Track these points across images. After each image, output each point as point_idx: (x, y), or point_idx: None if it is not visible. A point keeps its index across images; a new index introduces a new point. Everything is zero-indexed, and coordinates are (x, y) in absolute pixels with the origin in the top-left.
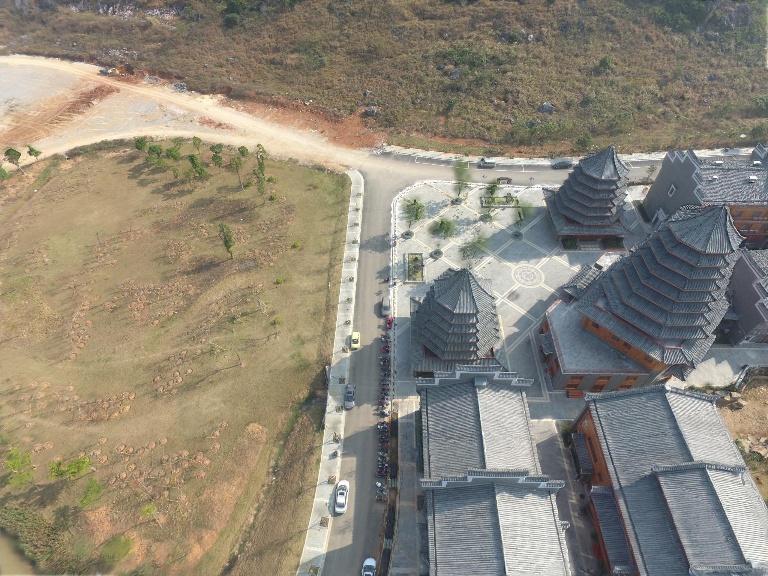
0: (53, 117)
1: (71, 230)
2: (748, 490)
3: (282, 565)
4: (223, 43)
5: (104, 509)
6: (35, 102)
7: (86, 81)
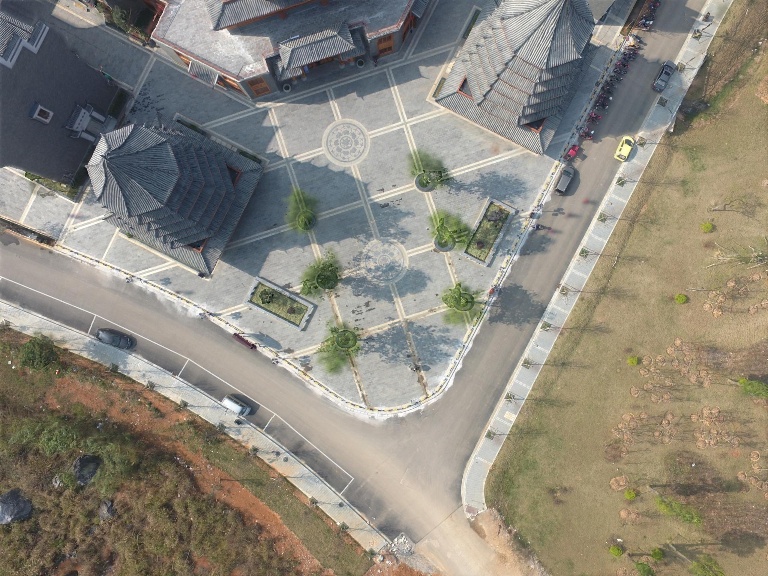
0: None
1: None
2: None
3: None
4: None
5: None
6: None
7: None
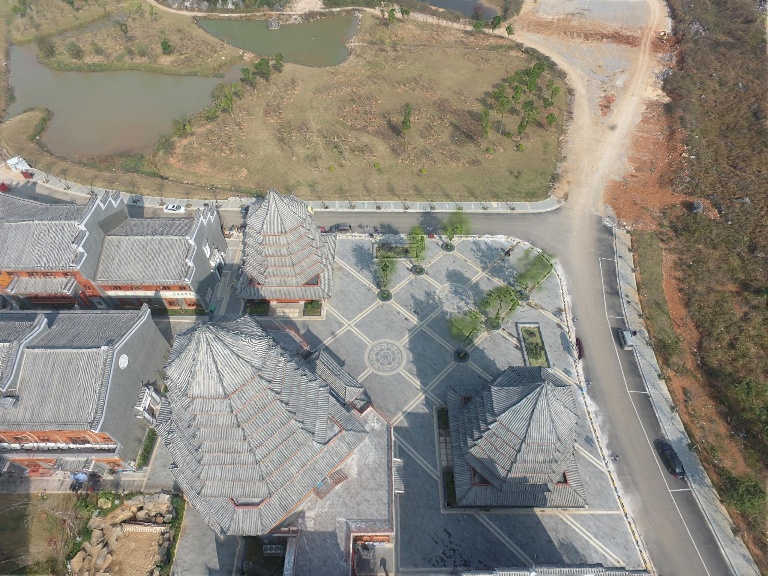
0: (573, 30)
1: (432, 69)
2: None
3: (146, 189)
4: (767, 71)
5: (210, 127)
6: (591, 19)
7: (639, 29)
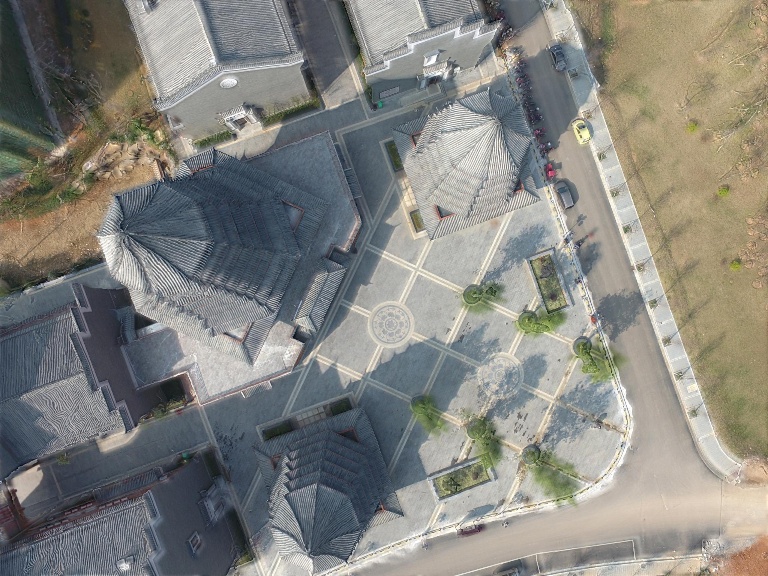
0: None
1: None
2: (134, 1)
3: None
4: None
5: None
6: None
7: None
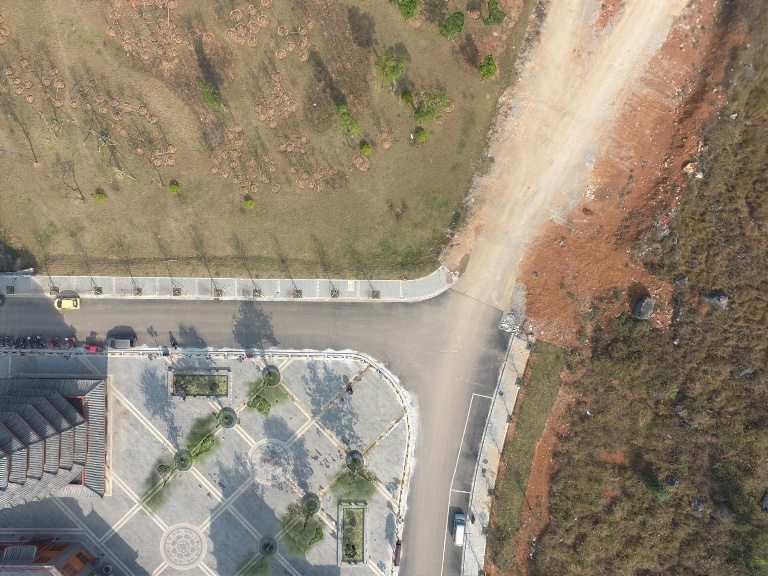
0: None
1: None
2: None
3: None
4: None
5: None
6: None
7: None
